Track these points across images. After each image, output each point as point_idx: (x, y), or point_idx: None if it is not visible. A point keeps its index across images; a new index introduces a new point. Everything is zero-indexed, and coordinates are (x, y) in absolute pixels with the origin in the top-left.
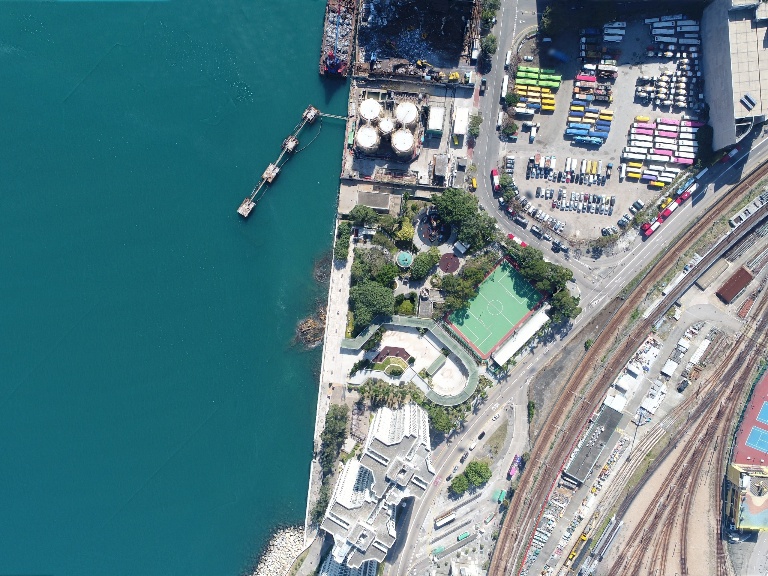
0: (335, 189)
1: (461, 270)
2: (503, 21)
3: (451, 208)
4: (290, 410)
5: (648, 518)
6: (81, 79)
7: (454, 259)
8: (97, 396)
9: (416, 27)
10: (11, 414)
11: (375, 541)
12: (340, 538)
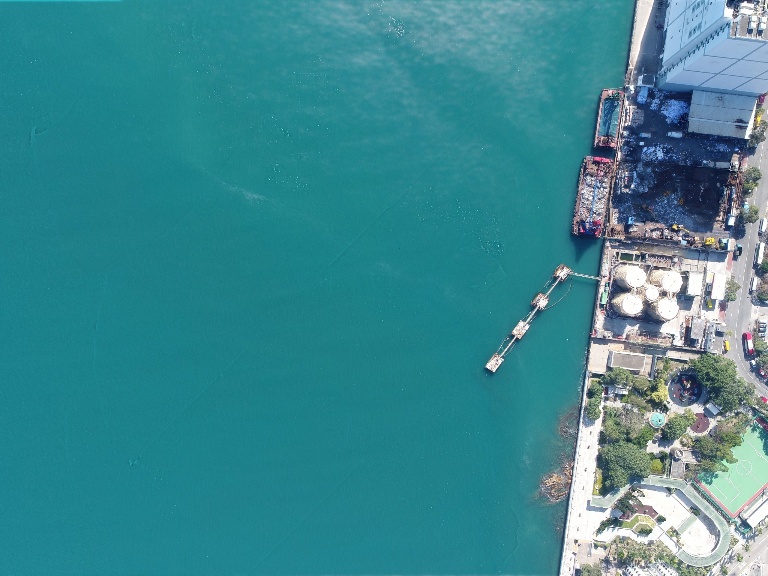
0: (584, 346)
1: (713, 431)
2: (758, 188)
3: (713, 375)
4: (532, 565)
5: None
6: (350, 243)
7: (704, 419)
8: (354, 559)
9: (671, 192)
10: None
11: None
12: None
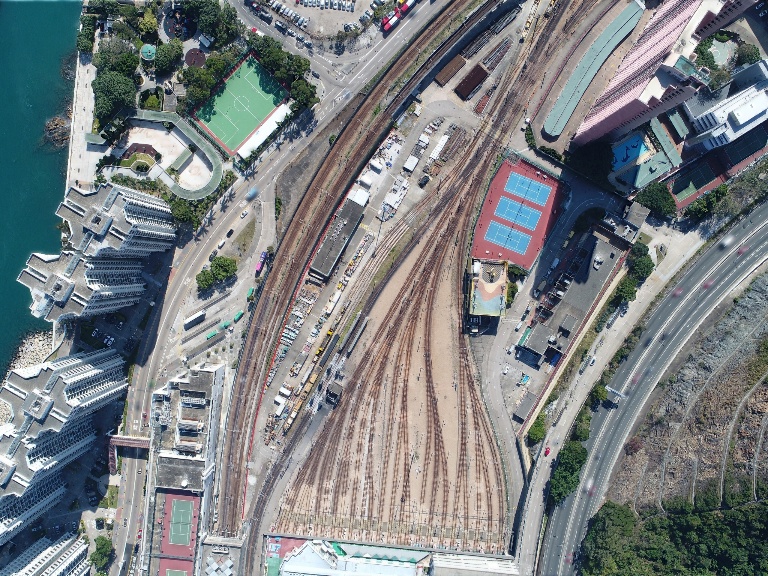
0: None
1: (205, 64)
2: None
3: None
4: (38, 211)
5: (393, 313)
6: None
7: (200, 54)
8: None
9: None
10: None
11: (74, 295)
12: (38, 292)
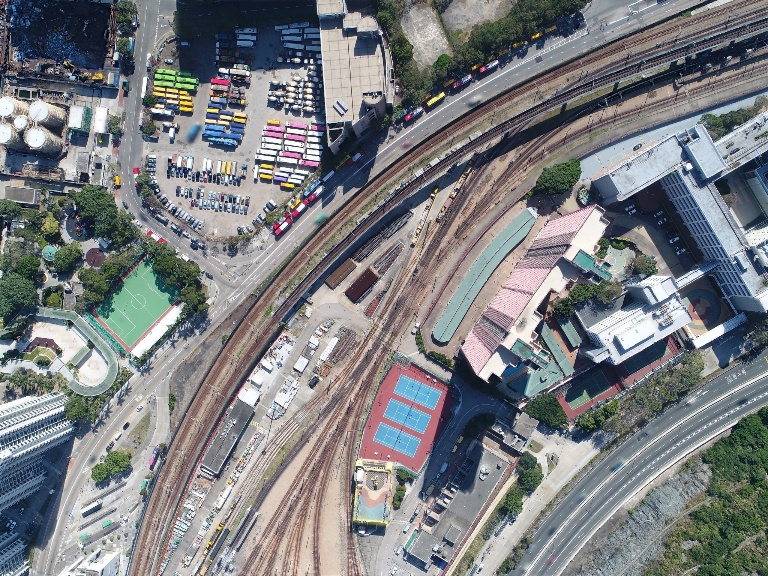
0: None
1: None
2: (146, 25)
3: (83, 204)
4: None
5: (282, 510)
6: None
7: (100, 254)
8: None
9: (64, 29)
10: None
11: None
12: None
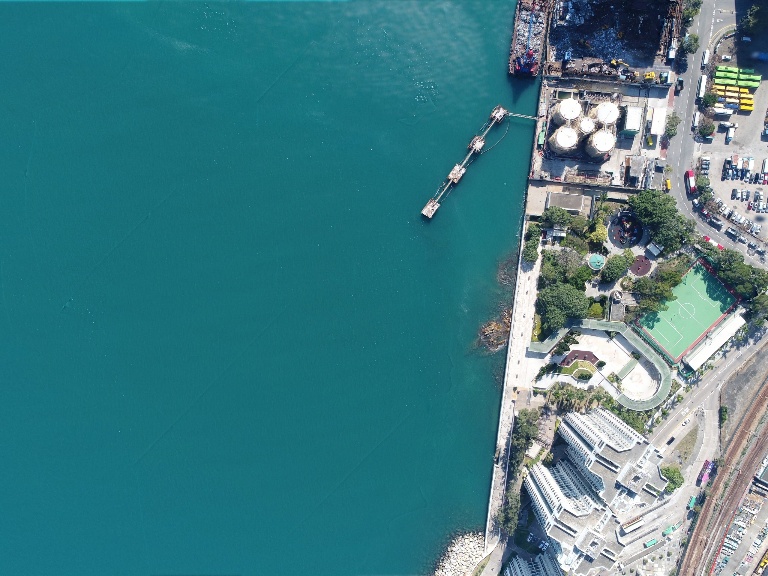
0: (522, 190)
1: (654, 273)
2: (700, 20)
3: (651, 210)
4: (472, 414)
5: None
6: (276, 78)
7: (645, 261)
8: (286, 400)
9: (610, 26)
10: (198, 418)
11: (603, 549)
12: (567, 546)
